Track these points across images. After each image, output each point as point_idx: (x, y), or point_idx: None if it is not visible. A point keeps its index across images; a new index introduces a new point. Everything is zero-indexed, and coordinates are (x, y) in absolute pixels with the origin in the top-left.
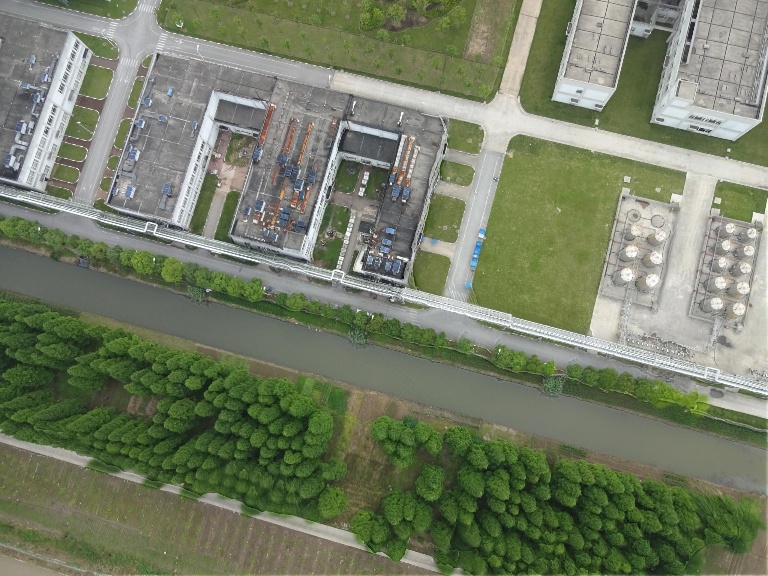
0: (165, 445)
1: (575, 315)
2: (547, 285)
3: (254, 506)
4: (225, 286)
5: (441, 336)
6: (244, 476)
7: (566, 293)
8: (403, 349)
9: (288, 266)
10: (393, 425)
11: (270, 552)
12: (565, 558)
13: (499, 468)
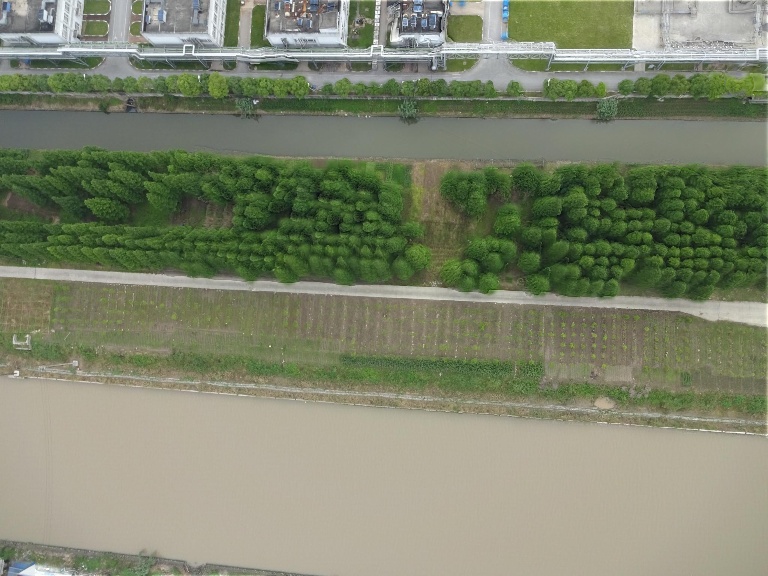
0: (248, 242)
1: (615, 39)
2: (582, 18)
3: (344, 280)
4: (271, 87)
5: (489, 83)
6: (329, 250)
7: (602, 21)
8: (454, 113)
9: (327, 55)
10: (459, 186)
11: (368, 323)
12: (654, 243)
13: (572, 183)
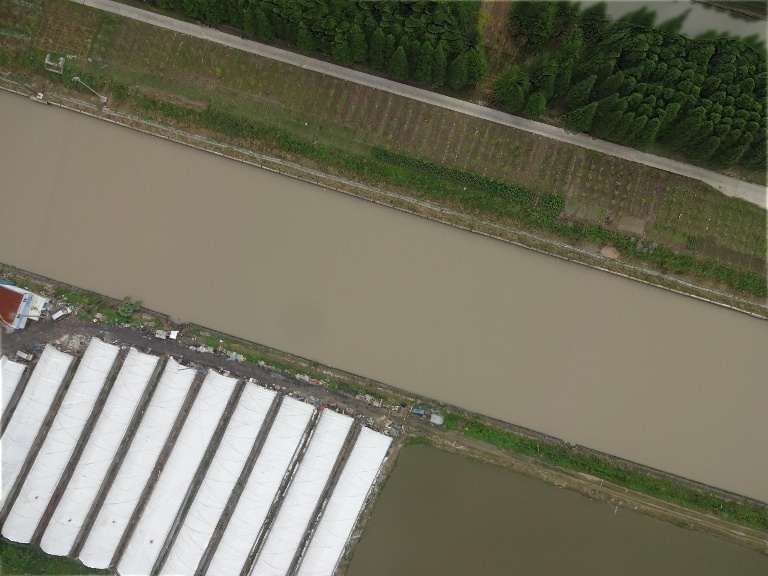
0: (313, 13)
1: None
2: None
3: (397, 74)
4: None
5: None
6: (391, 39)
7: None
8: None
9: None
10: (525, 22)
11: (408, 124)
12: (701, 98)
13: (637, 31)
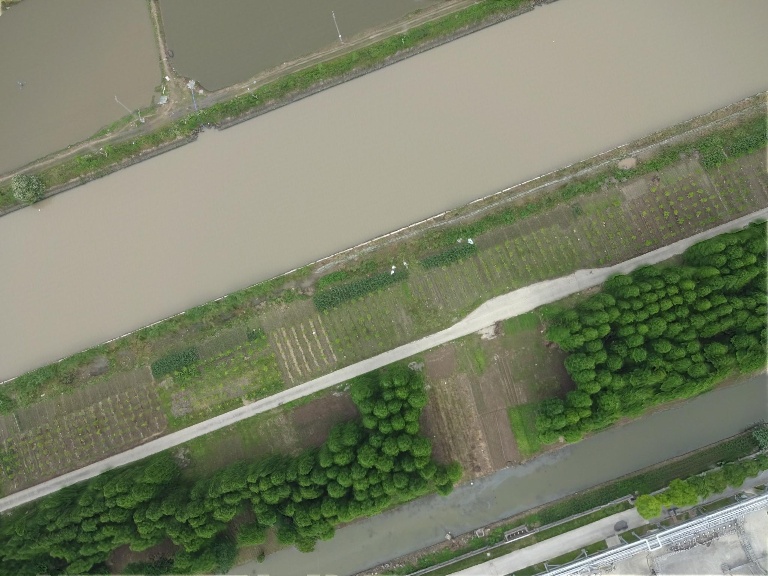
0: None
1: None
2: None
3: None
4: None
5: None
6: None
7: None
8: None
9: None
10: None
11: None
12: (696, 301)
13: None
